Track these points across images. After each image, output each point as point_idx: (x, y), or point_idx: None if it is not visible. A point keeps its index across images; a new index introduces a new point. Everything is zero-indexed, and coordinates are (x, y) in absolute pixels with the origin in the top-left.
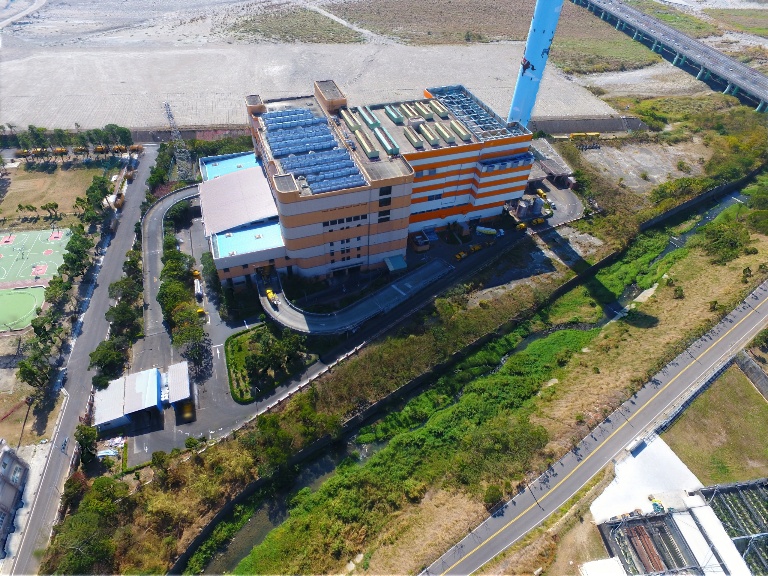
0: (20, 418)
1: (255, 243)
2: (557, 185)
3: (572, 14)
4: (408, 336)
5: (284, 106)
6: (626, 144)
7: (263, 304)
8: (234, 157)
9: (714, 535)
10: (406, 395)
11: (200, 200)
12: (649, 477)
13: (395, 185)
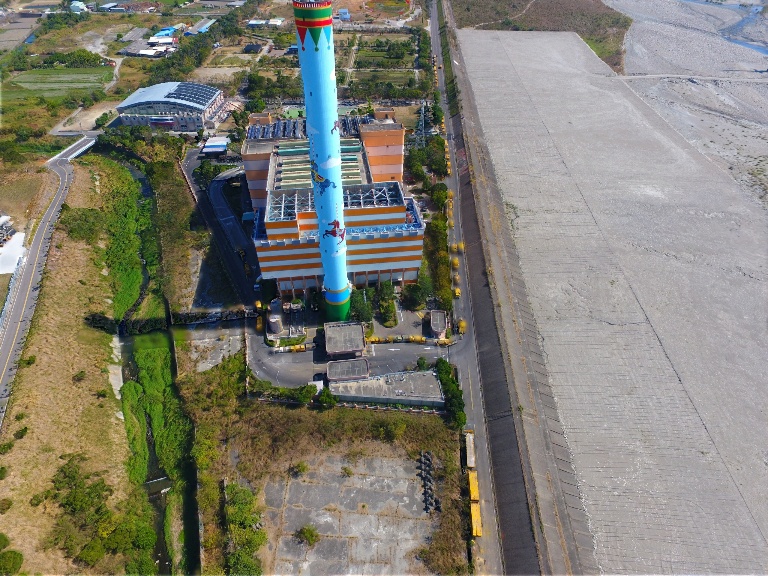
0: None
1: None
2: None
3: None
4: None
5: None
6: None
7: None
8: None
9: None
10: None
11: None
12: (6, 258)
13: None
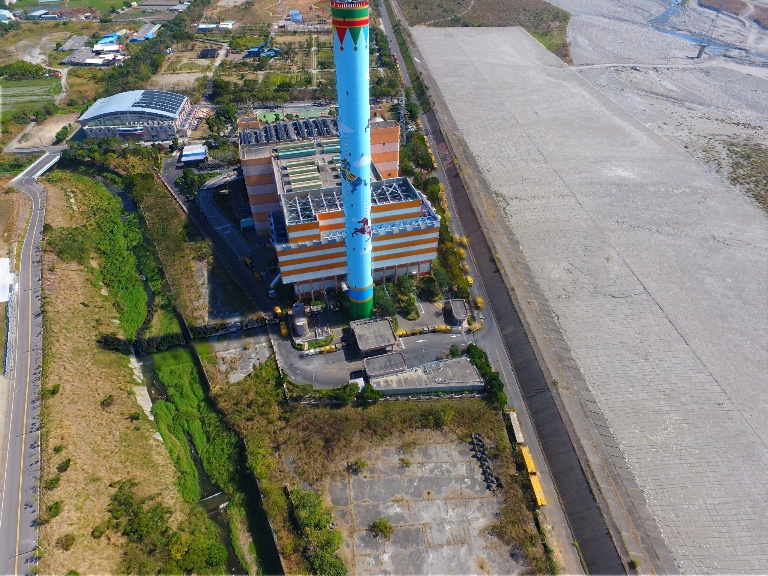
0: (203, 135)
1: None
2: (361, 374)
3: None
4: None
5: None
6: (521, 561)
7: None
8: None
9: None
10: None
11: None
12: None
13: None
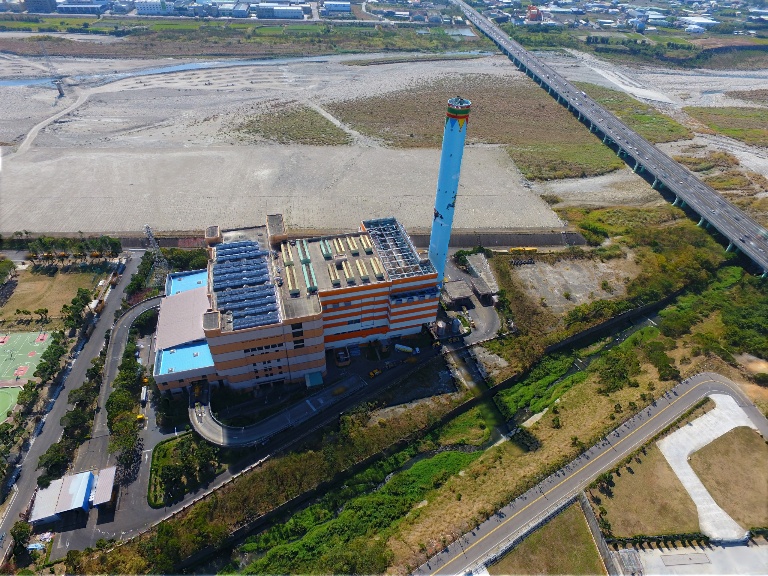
0: None
1: (192, 361)
2: (483, 302)
3: (551, 115)
4: (308, 451)
5: (238, 236)
6: (560, 260)
7: (190, 416)
8: (197, 273)
9: None
10: (294, 508)
11: (159, 315)
12: None
13: (305, 322)
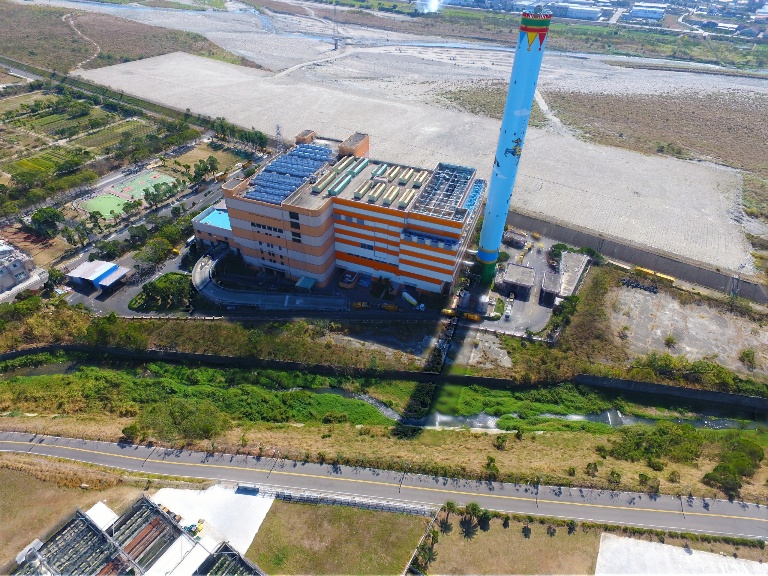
0: (55, 256)
1: (225, 223)
2: (543, 301)
3: None
4: (251, 330)
5: (325, 144)
6: (702, 304)
7: (198, 262)
8: None
9: (181, 570)
10: (206, 363)
11: None
12: (222, 511)
13: (301, 214)
